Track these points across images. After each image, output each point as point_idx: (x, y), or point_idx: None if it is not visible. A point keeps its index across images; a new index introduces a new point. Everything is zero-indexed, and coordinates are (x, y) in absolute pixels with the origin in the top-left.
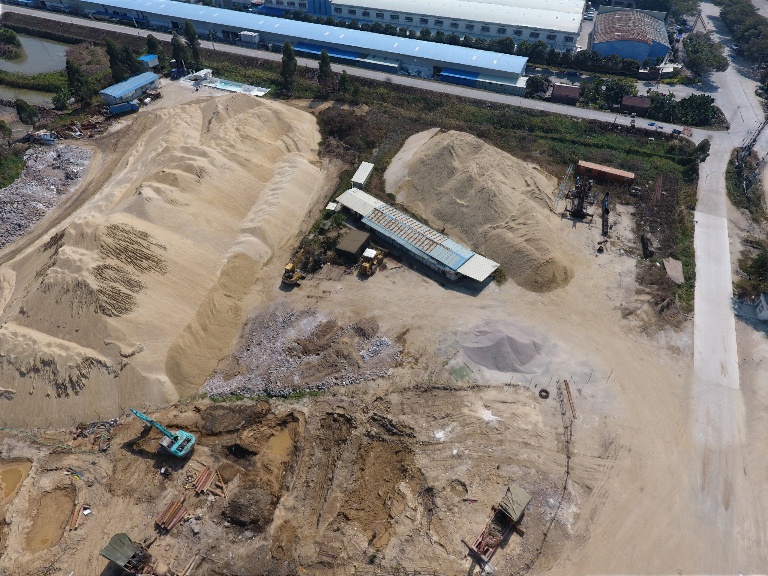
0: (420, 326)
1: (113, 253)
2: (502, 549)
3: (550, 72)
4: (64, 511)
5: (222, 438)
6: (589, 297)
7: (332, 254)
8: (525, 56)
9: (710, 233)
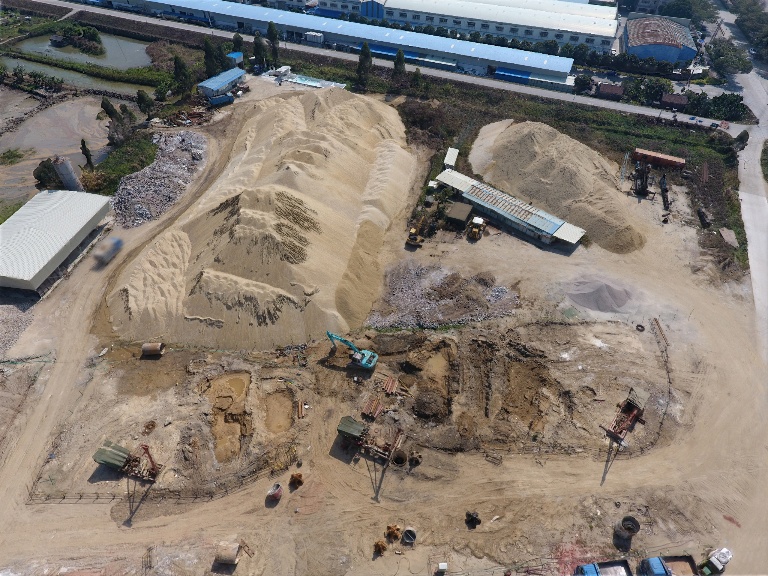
0: (529, 278)
1: (284, 214)
2: (630, 432)
3: (591, 72)
4: (287, 407)
5: (395, 357)
6: (662, 257)
7: (442, 222)
8: (569, 57)
9: (754, 209)
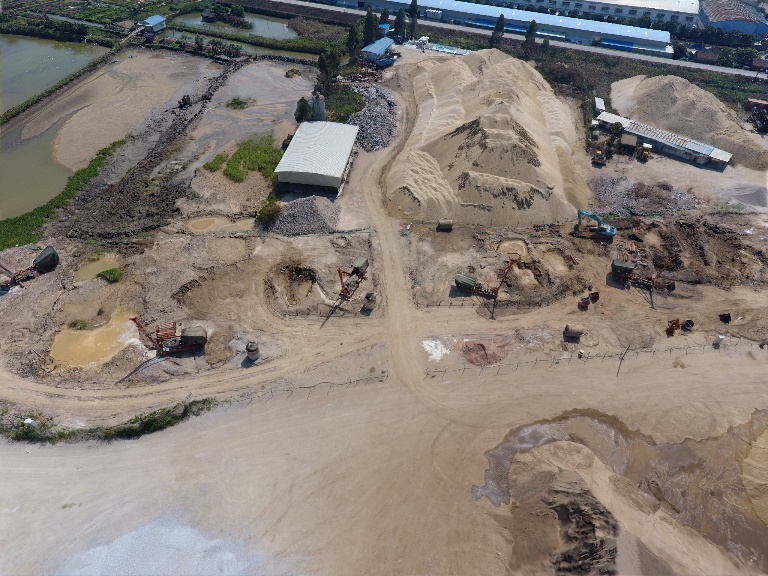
0: (698, 186)
1: None
2: None
3: None
4: (560, 260)
5: (624, 231)
6: None
7: (615, 149)
8: None
9: None
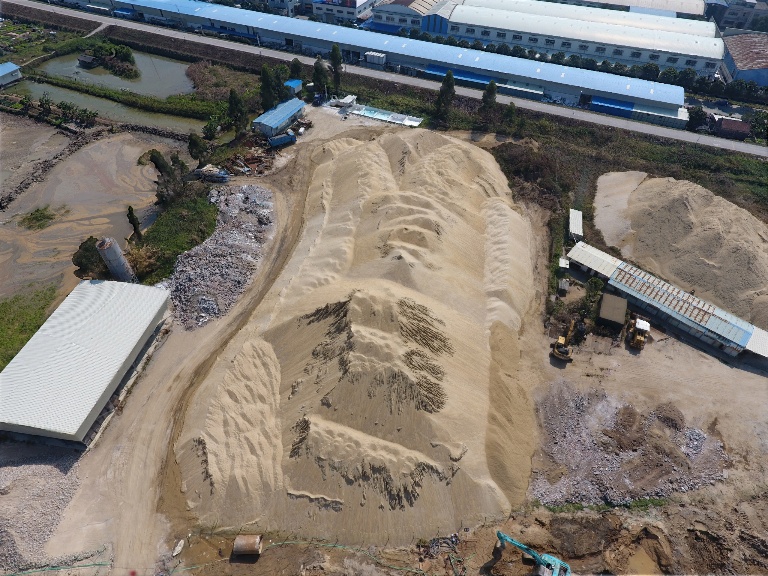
0: (727, 414)
1: (411, 335)
2: None
3: (697, 101)
4: None
5: (587, 562)
6: None
7: (590, 322)
8: (673, 84)
9: None
